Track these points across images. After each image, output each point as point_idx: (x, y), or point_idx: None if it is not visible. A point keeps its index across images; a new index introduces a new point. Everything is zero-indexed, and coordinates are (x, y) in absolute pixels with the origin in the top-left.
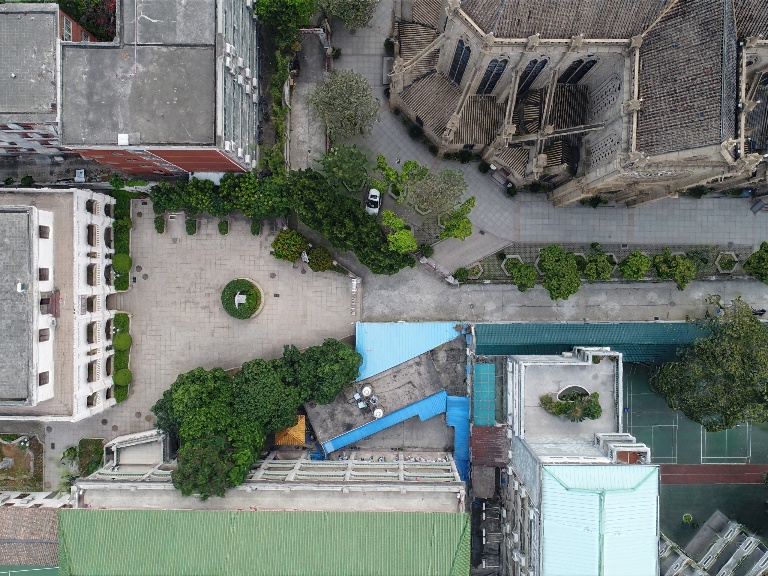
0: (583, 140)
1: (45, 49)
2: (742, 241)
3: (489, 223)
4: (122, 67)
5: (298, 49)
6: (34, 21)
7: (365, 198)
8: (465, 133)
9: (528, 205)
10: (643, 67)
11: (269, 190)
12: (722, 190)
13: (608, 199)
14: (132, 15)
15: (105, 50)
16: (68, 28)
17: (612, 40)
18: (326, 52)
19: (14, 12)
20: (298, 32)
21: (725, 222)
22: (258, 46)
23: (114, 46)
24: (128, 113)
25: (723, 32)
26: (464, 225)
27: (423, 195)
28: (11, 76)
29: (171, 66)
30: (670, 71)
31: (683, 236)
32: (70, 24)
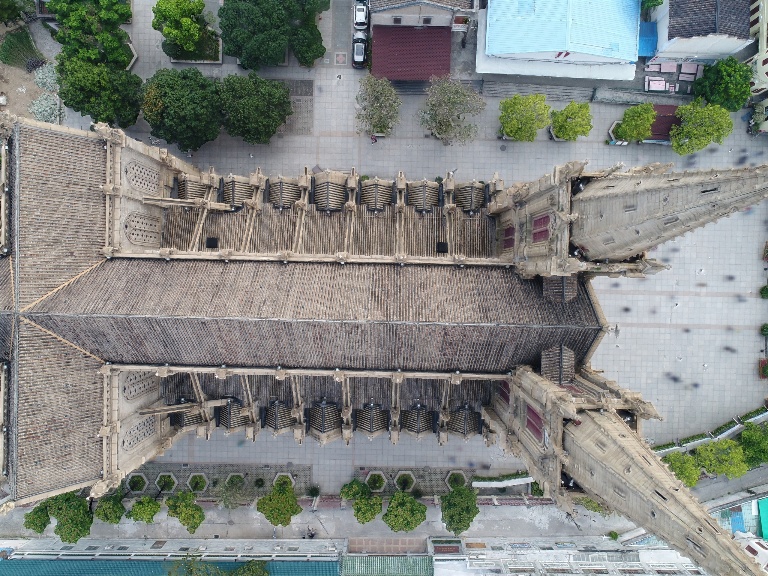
0: None
1: None
2: (301, 461)
3: None
4: None
5: None
6: None
7: None
8: None
9: None
10: (10, 389)
11: None
12: None
13: None
14: None
15: None
16: None
17: None
18: None
19: None
20: None
21: (284, 443)
22: None
23: None
24: None
25: (13, 394)
26: None
27: None
28: None
29: None
30: None
31: (243, 456)
32: None
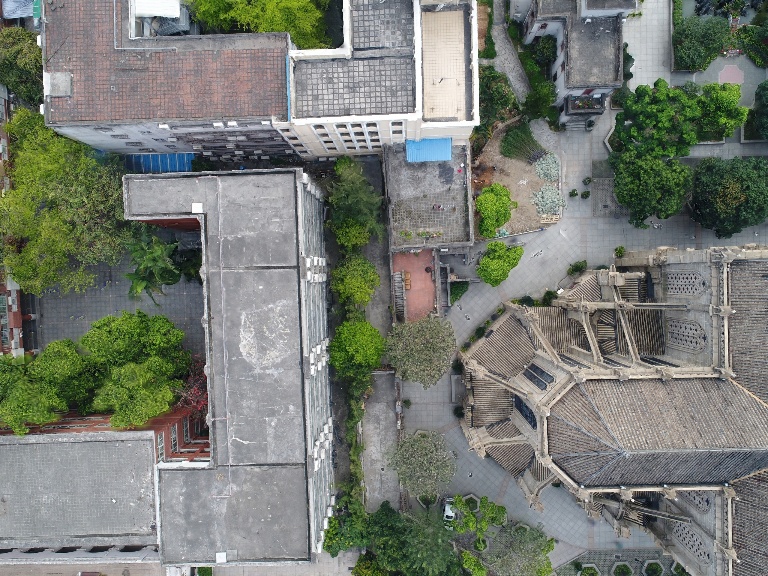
0: (663, 499)
1: (143, 474)
2: None
3: (563, 532)
4: (217, 487)
5: (372, 393)
6: (131, 448)
7: (440, 516)
8: (541, 474)
9: None
10: (736, 512)
11: (350, 533)
12: None
13: None
14: (224, 438)
15: (200, 472)
16: (161, 440)
17: (704, 488)
18: (395, 376)
19: (112, 440)
20: (371, 376)
21: None
22: (329, 376)
23: (208, 468)
24: (224, 531)
25: None
26: (545, 570)
27: (509, 571)
28: (112, 501)
29: (264, 485)
30: (767, 533)
31: None
32: (162, 434)
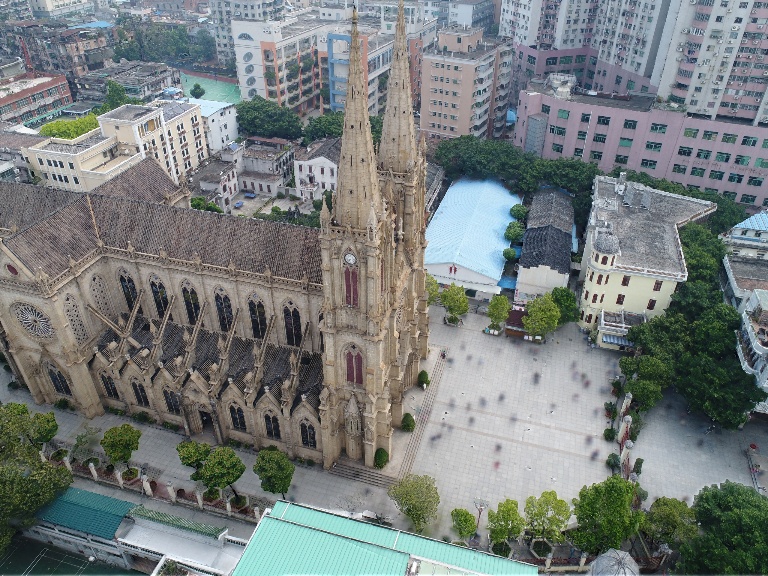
0: None
1: None
2: (157, 465)
3: None
4: None
5: None
6: None
7: None
8: None
9: (18, 399)
10: None
11: None
12: (161, 420)
13: (76, 408)
14: None
15: None
16: None
17: None
18: None
19: None
20: None
21: (153, 447)
22: None
23: None
24: None
25: None
26: None
27: None
28: None
29: None
30: None
31: None
32: None
